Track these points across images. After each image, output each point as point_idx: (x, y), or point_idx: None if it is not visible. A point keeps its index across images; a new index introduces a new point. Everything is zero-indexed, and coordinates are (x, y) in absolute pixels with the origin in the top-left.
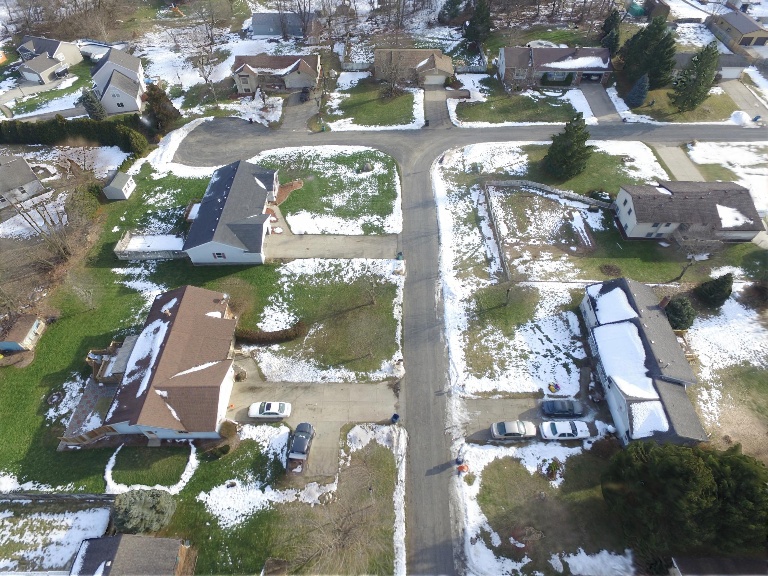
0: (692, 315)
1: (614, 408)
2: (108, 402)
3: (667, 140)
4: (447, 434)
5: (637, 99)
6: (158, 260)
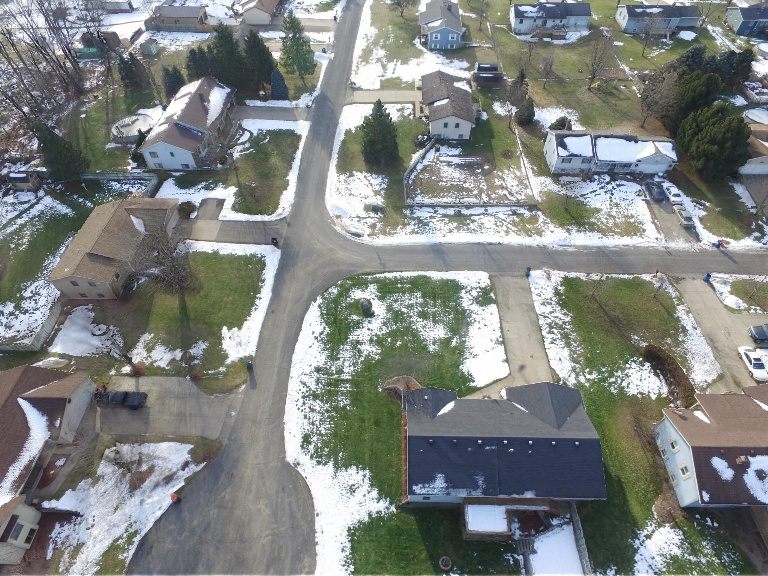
0: None
1: None
2: None
3: (344, 94)
4: (701, 251)
5: (285, 90)
6: None
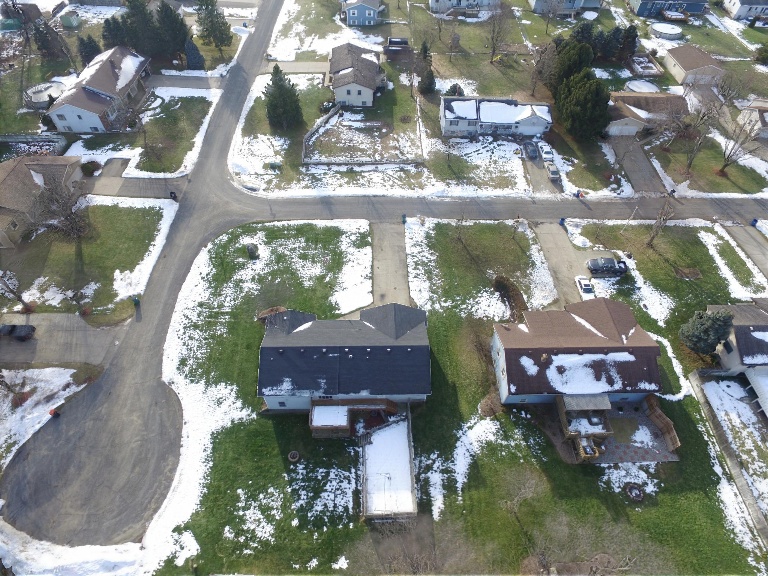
0: (461, 88)
1: (527, 130)
2: (618, 431)
3: (259, 65)
4: (562, 200)
5: (200, 60)
6: (413, 457)
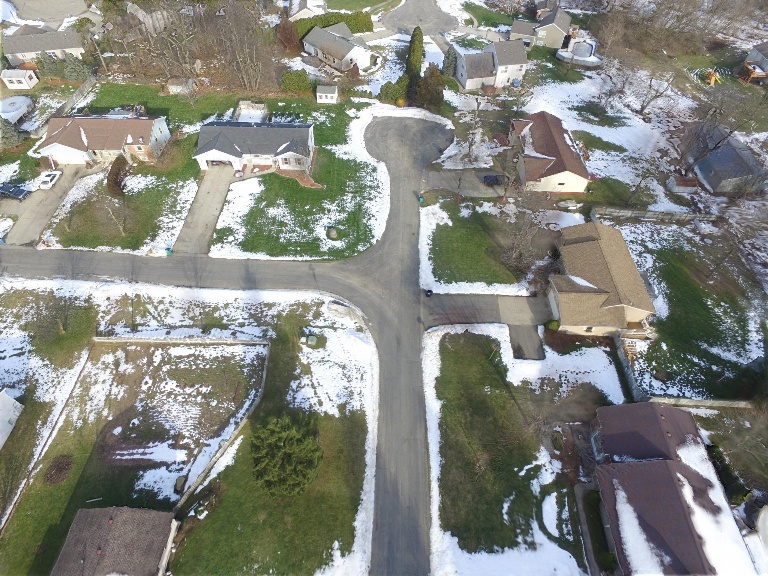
0: None
1: None
2: None
3: None
4: None
5: None
6: None
